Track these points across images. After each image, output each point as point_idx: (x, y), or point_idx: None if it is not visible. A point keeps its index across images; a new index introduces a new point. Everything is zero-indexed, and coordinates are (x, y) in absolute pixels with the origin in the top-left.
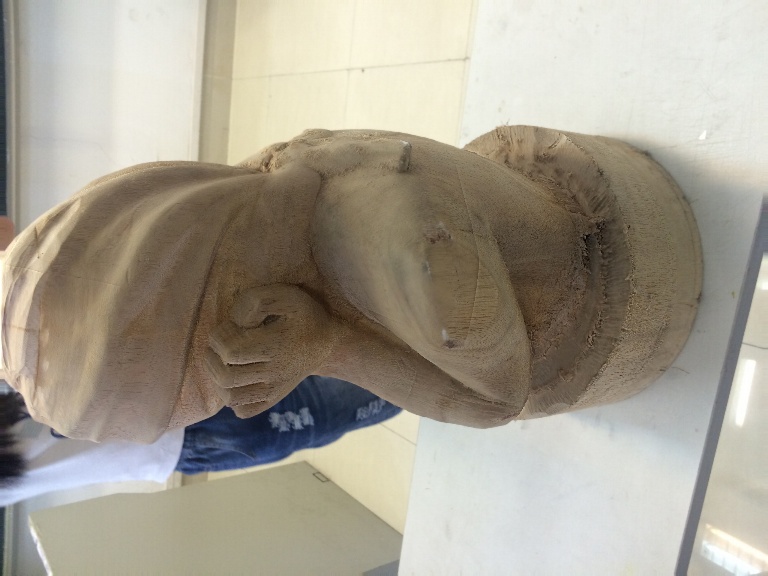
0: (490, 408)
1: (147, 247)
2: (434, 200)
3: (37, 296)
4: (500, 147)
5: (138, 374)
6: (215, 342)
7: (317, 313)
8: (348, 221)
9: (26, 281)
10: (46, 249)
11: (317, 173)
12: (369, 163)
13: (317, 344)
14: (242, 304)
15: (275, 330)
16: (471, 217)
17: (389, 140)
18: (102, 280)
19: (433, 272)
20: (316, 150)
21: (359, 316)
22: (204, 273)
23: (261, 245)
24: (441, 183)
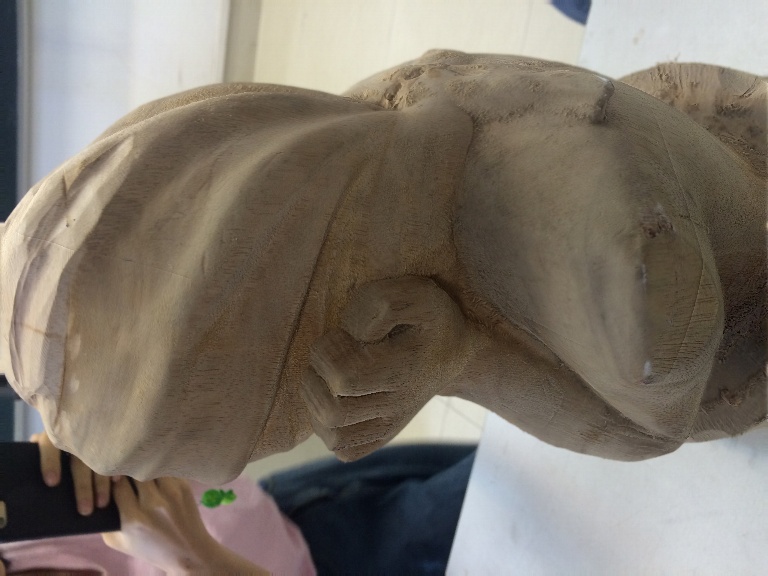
0: (647, 443)
1: (235, 220)
2: (645, 169)
3: (64, 286)
4: (663, 91)
5: (209, 405)
6: (320, 361)
7: (456, 319)
8: (517, 192)
9: (48, 261)
10: (79, 213)
11: (468, 116)
12: (546, 106)
13: (451, 361)
14: (360, 306)
15: (405, 347)
16: (685, 195)
17: (577, 73)
18: (164, 267)
19: (649, 280)
20: (468, 81)
21: (499, 319)
22: (313, 261)
23: (390, 220)
24: (646, 142)
